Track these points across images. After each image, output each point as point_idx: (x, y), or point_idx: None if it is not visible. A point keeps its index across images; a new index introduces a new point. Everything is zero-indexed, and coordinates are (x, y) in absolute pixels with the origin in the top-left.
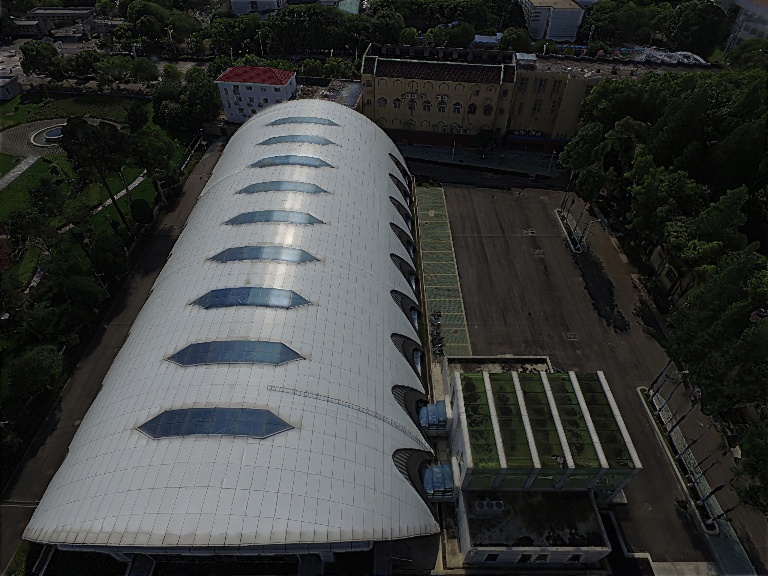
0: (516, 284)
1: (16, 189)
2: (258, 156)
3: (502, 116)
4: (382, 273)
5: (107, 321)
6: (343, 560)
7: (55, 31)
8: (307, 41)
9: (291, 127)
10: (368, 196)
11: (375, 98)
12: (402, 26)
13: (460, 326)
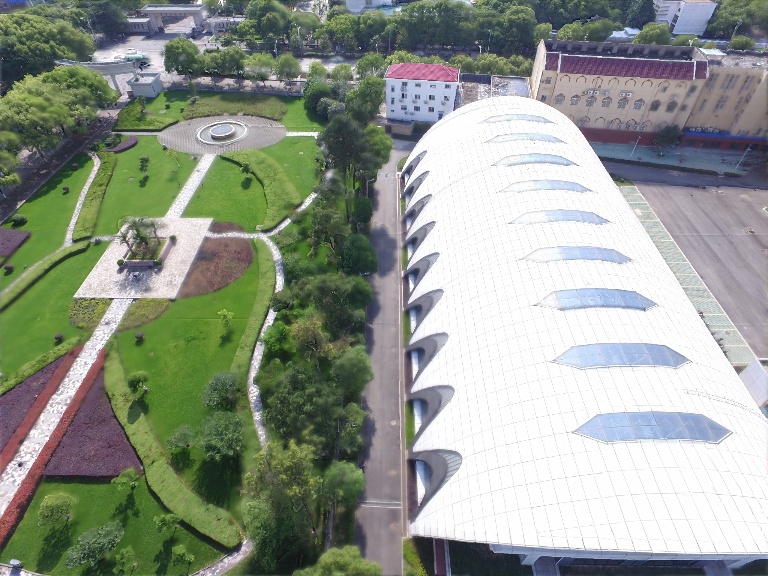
0: (763, 284)
1: (210, 187)
2: (496, 154)
3: (683, 113)
4: (671, 273)
5: (369, 320)
6: (748, 566)
7: (174, 28)
8: (437, 37)
9: (512, 125)
10: (617, 195)
11: (553, 95)
12: (534, 21)
13: (729, 327)
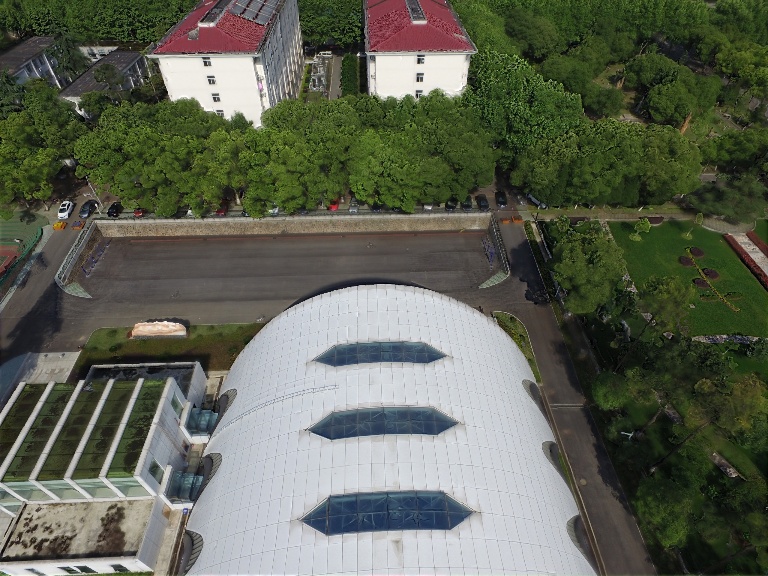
0: None
1: None
2: None
3: None
4: None
5: None
6: None
7: None
8: None
9: None
10: None
11: None
12: None
13: None
